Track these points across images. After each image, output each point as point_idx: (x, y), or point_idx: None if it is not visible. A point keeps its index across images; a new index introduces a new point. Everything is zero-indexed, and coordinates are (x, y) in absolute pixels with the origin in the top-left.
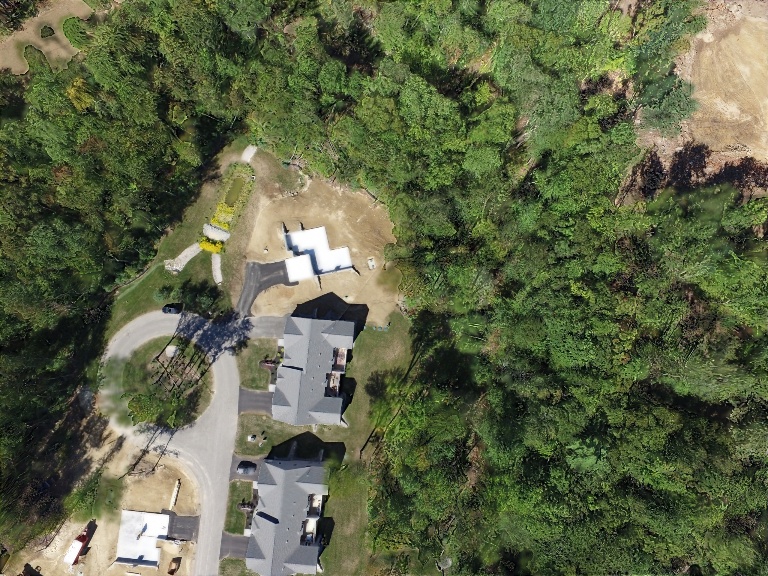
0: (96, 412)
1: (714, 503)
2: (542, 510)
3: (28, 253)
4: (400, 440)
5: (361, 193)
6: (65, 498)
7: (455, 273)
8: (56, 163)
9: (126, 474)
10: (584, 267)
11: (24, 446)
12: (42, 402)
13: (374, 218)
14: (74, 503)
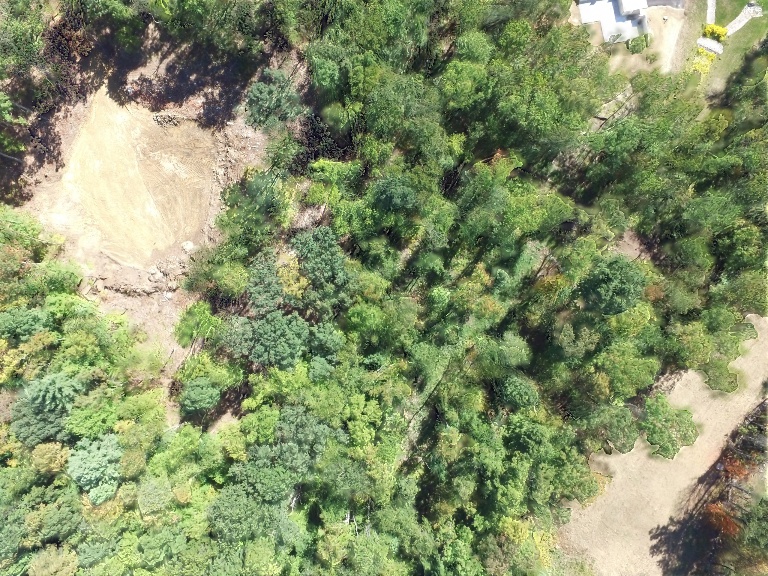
0: None
1: None
2: None
3: None
4: None
5: None
6: None
7: (472, 0)
8: None
9: None
10: None
11: None
12: None
13: None
14: None
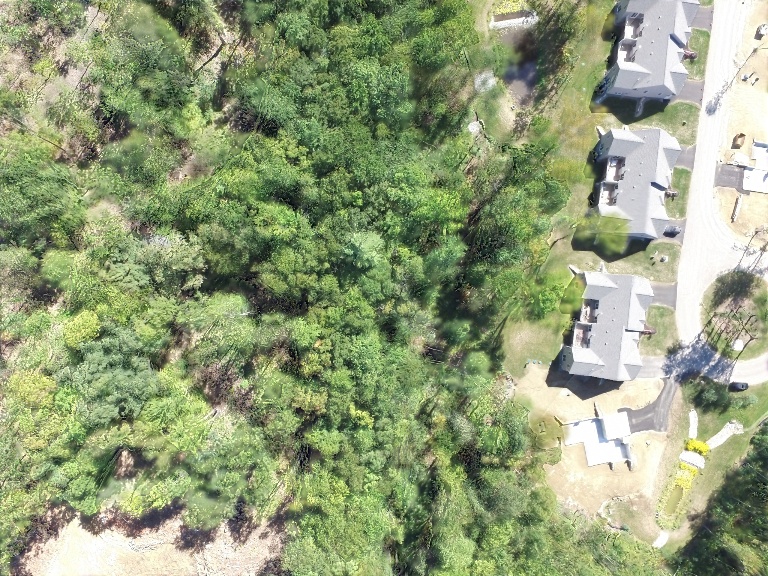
0: None
1: (235, 197)
2: (417, 197)
3: None
4: None
5: None
6: None
7: (455, 416)
8: None
9: None
10: (348, 436)
11: None
12: None
13: None
14: None
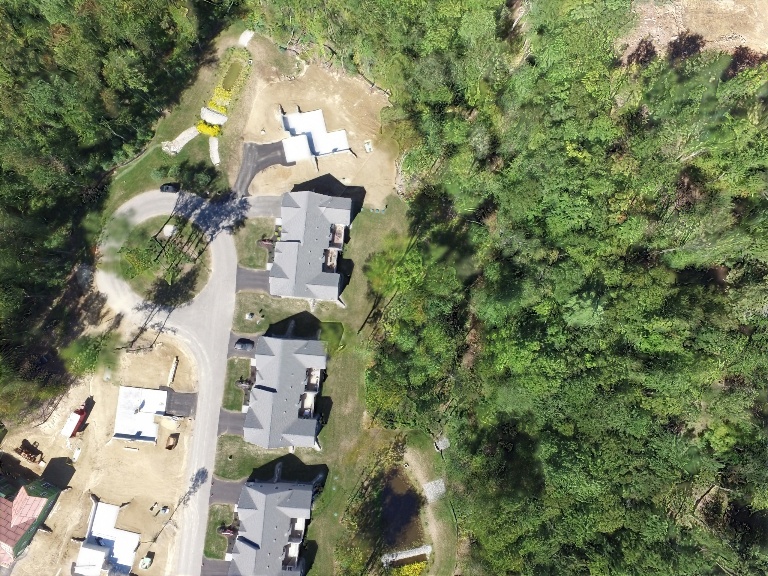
0: (94, 290)
1: (711, 357)
2: (539, 363)
3: (26, 110)
4: (397, 309)
5: (358, 79)
6: (63, 374)
7: (452, 158)
8: (54, 27)
9: (124, 347)
10: (580, 135)
11: (22, 314)
12: (40, 277)
13: (371, 103)
14: (72, 379)
